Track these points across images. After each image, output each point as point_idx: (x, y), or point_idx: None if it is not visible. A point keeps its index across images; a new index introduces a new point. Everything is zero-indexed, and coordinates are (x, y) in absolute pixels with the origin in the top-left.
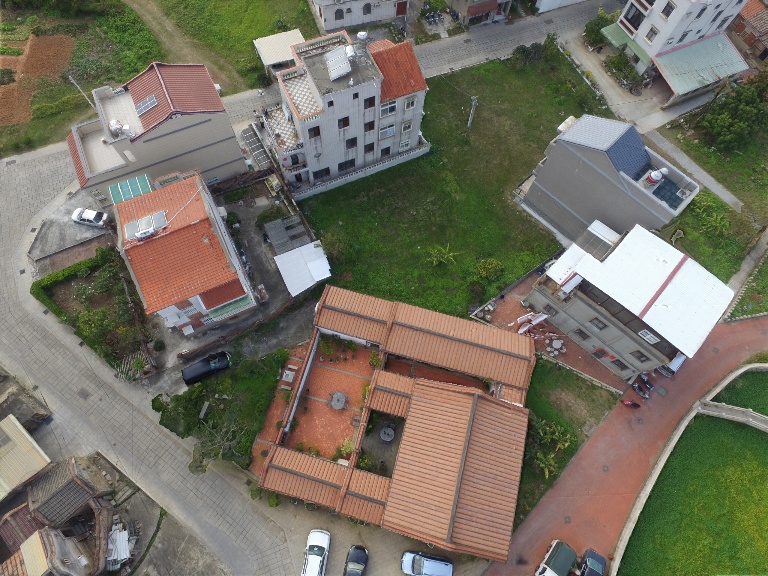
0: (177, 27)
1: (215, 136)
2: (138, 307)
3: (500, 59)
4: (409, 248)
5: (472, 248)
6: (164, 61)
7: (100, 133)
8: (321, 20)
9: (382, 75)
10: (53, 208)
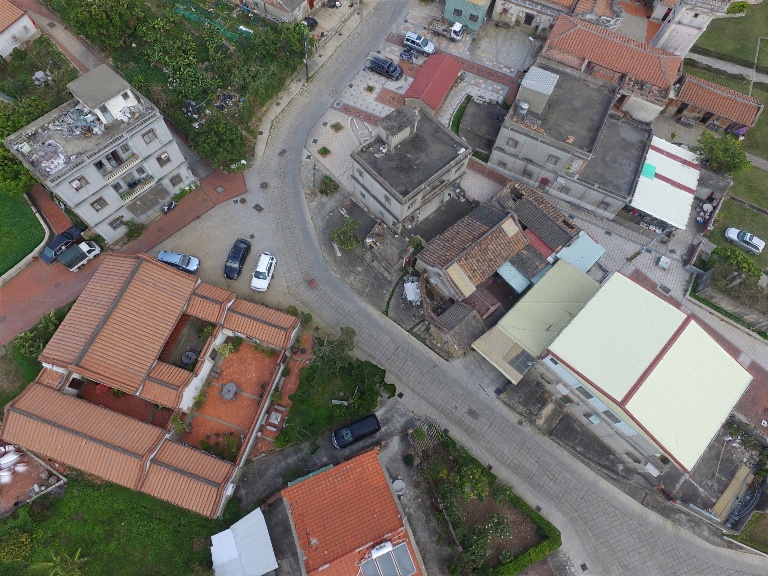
0: None
1: None
2: (435, 505)
3: None
4: None
5: None
6: None
7: None
8: None
9: None
10: None
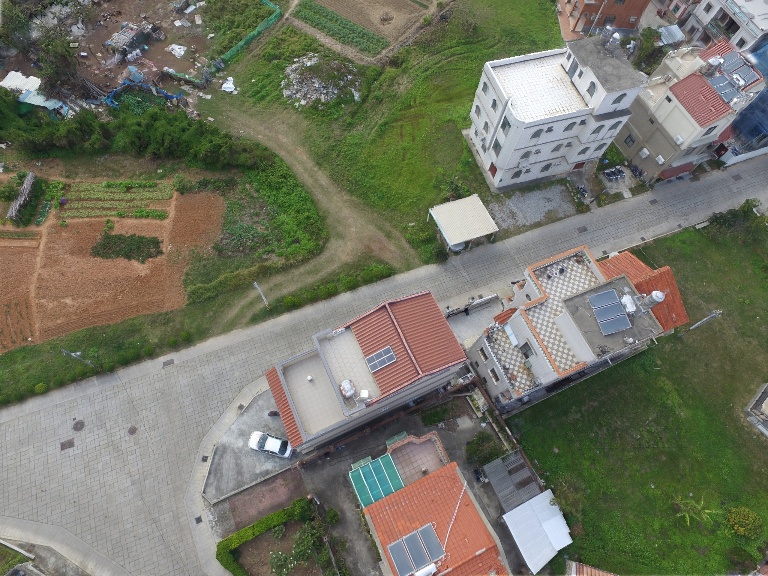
0: (332, 181)
1: (441, 376)
2: None
3: (695, 227)
4: (642, 488)
5: (713, 487)
6: (324, 226)
7: (302, 365)
8: (490, 175)
9: None
10: (224, 427)
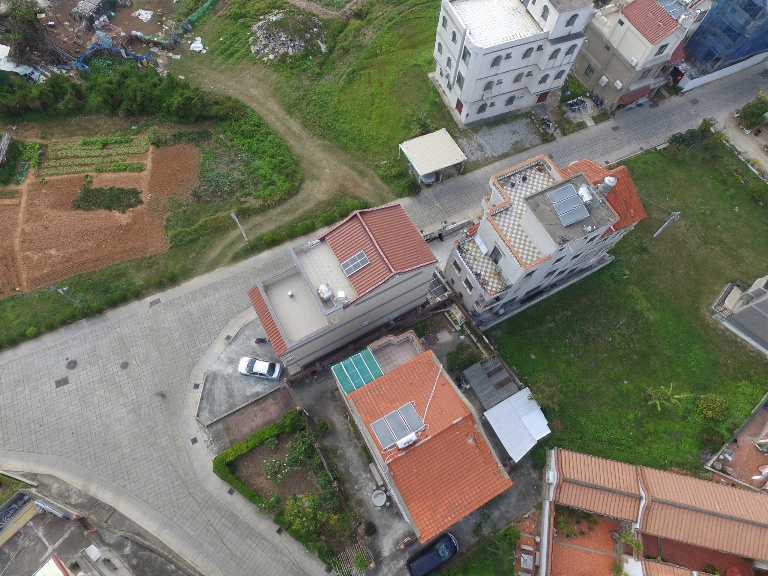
0: (304, 127)
1: (416, 283)
2: (341, 484)
3: (656, 148)
4: (615, 384)
5: (683, 379)
6: (299, 169)
7: (283, 284)
8: (458, 112)
9: (618, 216)
10: (213, 357)
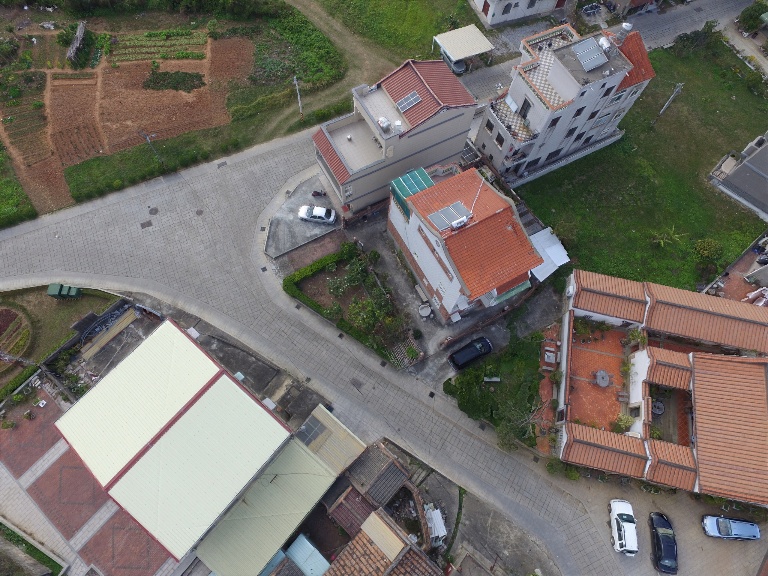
0: (345, 26)
1: (457, 130)
2: (392, 298)
3: (663, 47)
4: (625, 232)
5: (683, 229)
6: (342, 60)
7: (342, 131)
8: (484, 15)
9: (632, 64)
10: (276, 207)
